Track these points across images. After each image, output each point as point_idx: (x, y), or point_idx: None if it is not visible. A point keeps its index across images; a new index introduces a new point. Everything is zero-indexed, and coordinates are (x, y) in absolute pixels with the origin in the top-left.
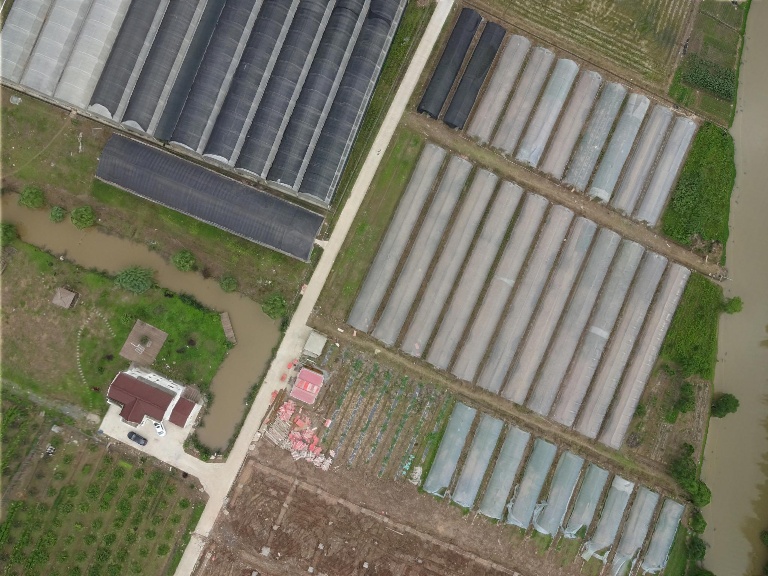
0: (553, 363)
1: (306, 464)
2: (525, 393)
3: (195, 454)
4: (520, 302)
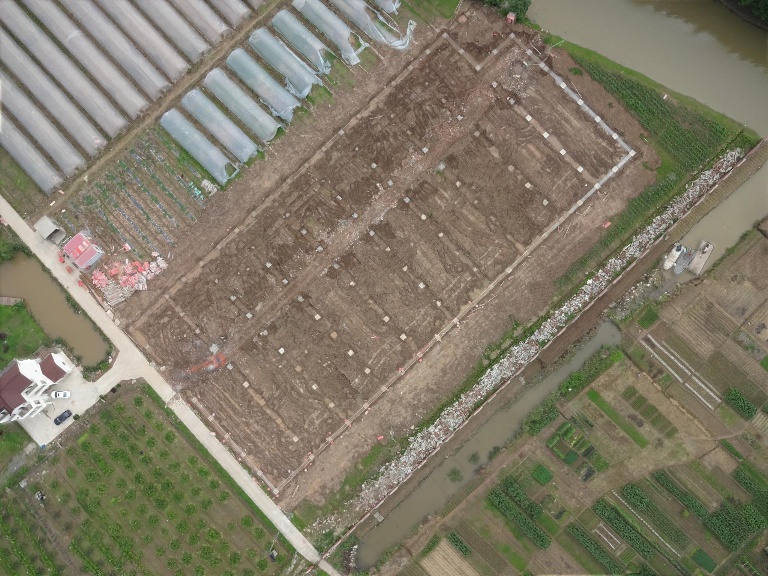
0: (168, 24)
1: (154, 281)
2: (180, 59)
3: (100, 374)
4: (101, 33)
